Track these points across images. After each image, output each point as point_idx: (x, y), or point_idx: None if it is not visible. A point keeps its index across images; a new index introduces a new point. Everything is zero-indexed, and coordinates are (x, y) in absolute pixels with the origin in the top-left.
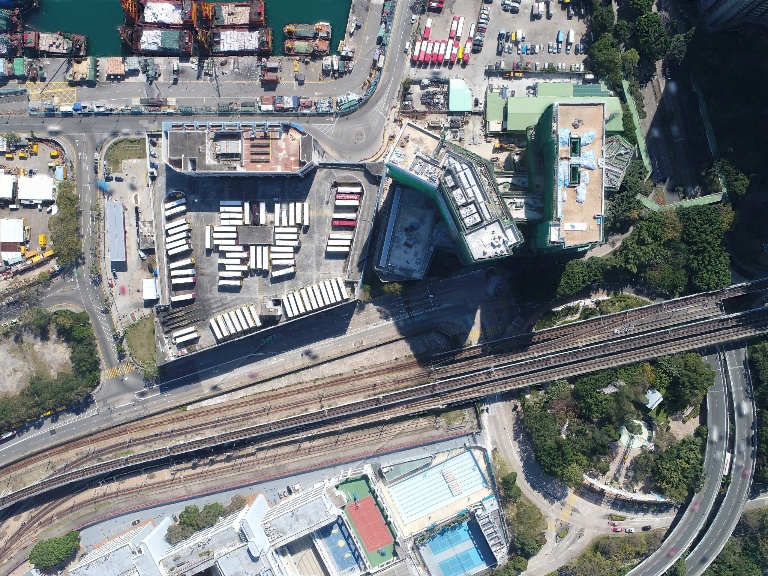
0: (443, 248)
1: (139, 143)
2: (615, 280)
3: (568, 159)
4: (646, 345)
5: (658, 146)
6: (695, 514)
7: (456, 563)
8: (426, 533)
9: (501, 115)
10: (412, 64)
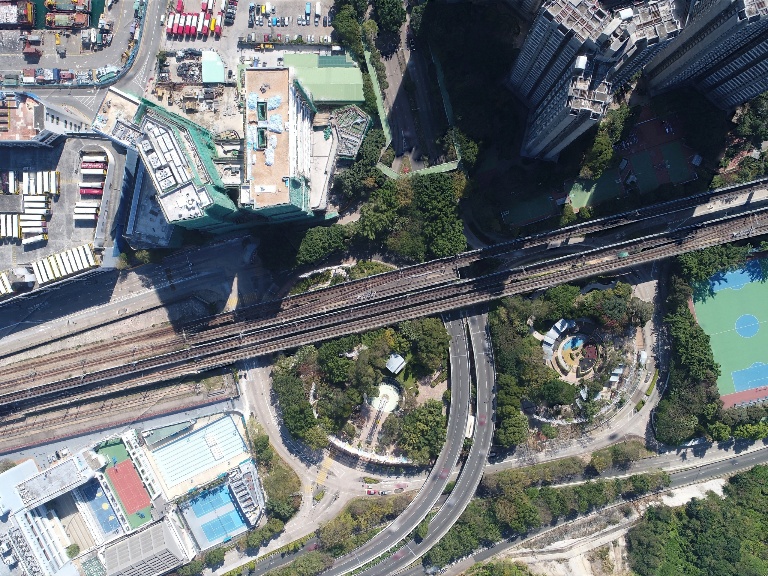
0: None
1: None
2: (364, 248)
3: (256, 123)
4: (387, 310)
5: (404, 116)
6: (439, 476)
7: (218, 525)
8: (187, 496)
9: None
10: (168, 37)
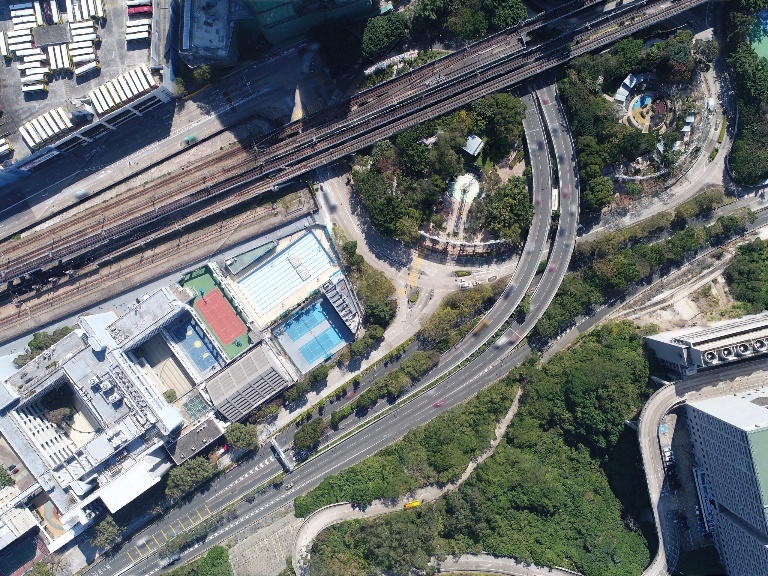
0: (243, 21)
1: None
2: (423, 39)
3: None
4: (458, 92)
5: None
6: (532, 252)
7: (316, 346)
8: (281, 320)
9: None
10: None
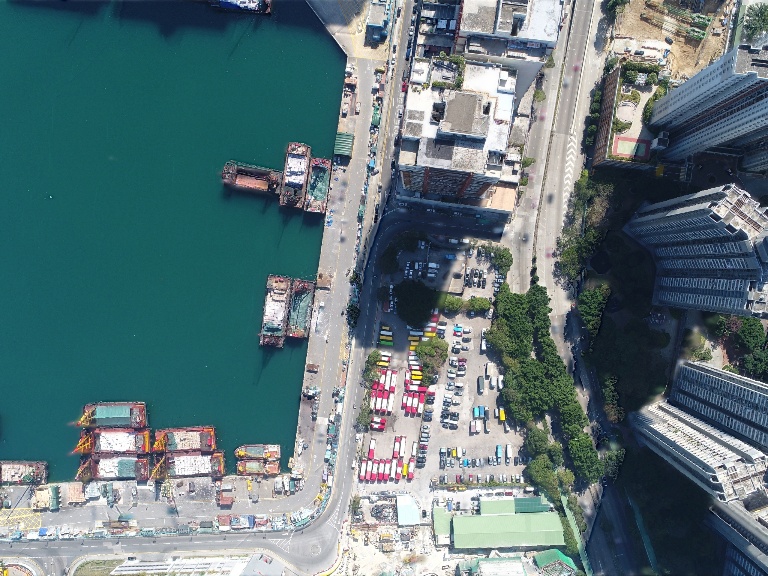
0: None
1: (105, 564)
2: None
3: None
4: None
5: (601, 549)
6: None
7: None
8: None
9: (448, 529)
10: (360, 480)
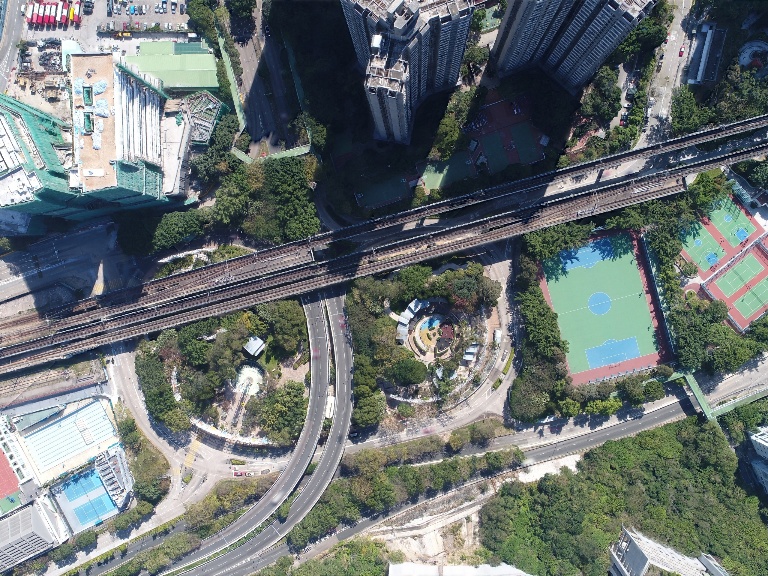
0: None
1: None
2: (225, 232)
3: (83, 108)
4: (244, 294)
5: (261, 102)
6: (301, 456)
7: (90, 509)
8: None
9: None
10: (29, 26)
